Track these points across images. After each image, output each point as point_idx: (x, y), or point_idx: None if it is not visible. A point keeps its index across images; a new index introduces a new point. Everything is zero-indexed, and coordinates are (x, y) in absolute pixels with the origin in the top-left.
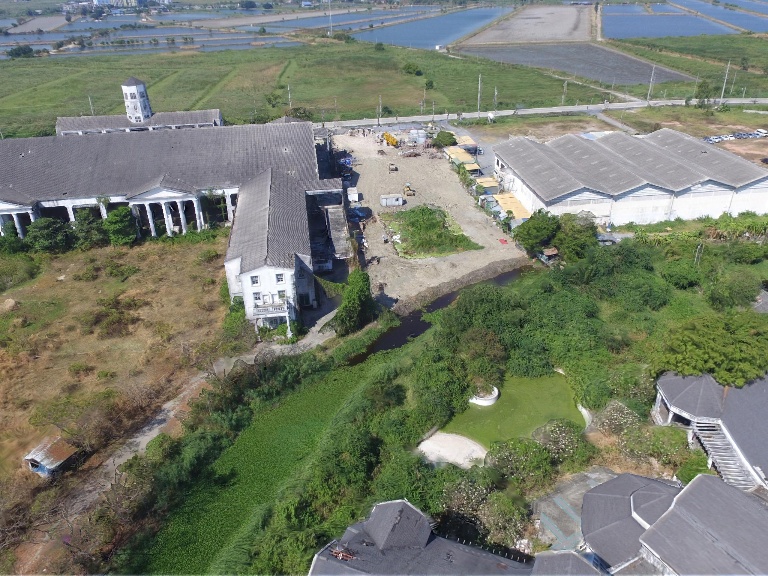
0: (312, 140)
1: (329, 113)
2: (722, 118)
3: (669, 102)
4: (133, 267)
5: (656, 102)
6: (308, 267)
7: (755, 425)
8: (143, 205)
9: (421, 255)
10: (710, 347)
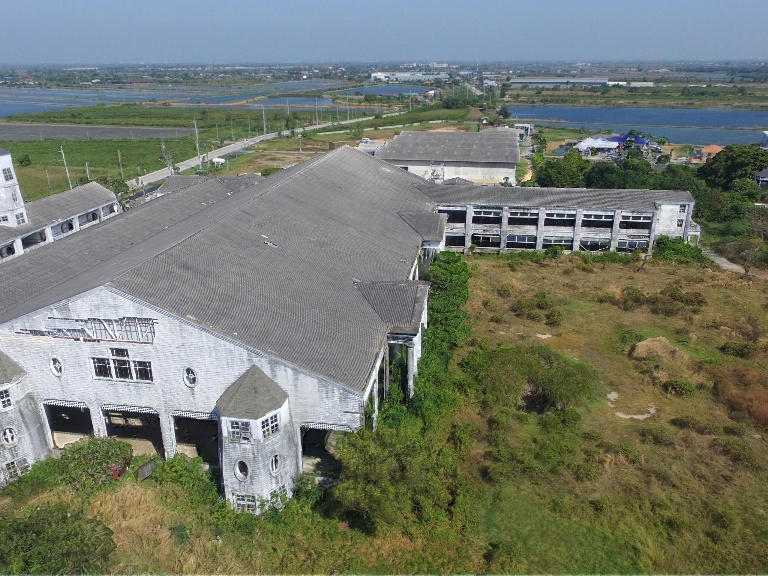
0: None
1: None
2: (322, 139)
3: (256, 139)
4: None
5: (250, 140)
6: None
7: None
8: None
9: None
10: (764, 152)
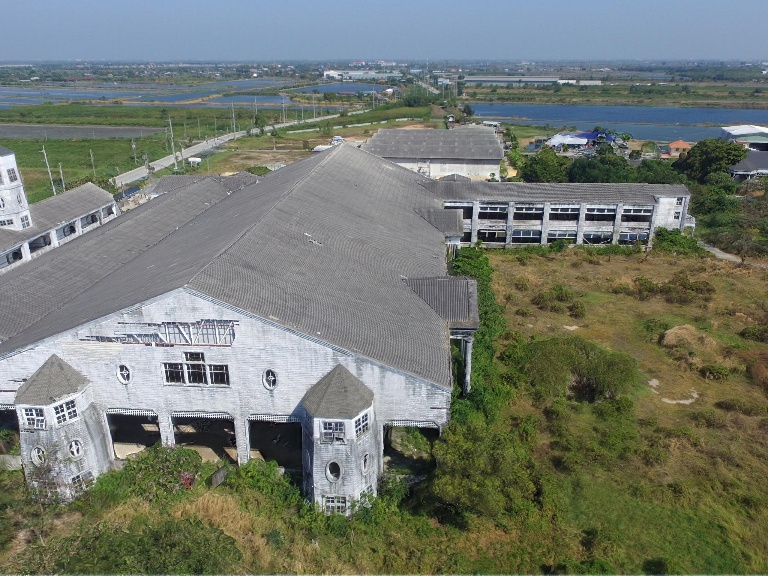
0: None
1: None
2: None
3: (224, 138)
4: None
5: None
6: None
7: (767, 162)
8: None
9: None
10: None
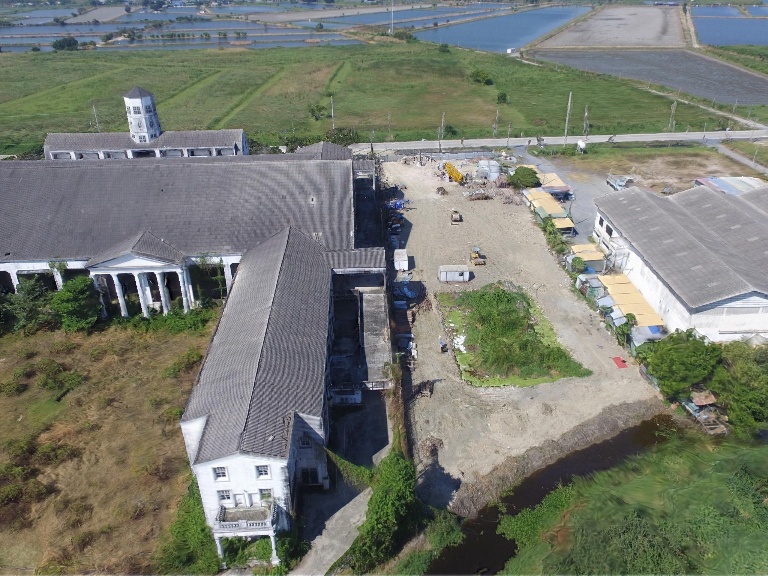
0: (349, 187)
1: (381, 131)
2: None
3: None
4: (78, 375)
5: None
6: (316, 433)
7: None
8: (109, 275)
9: (495, 380)
10: None
